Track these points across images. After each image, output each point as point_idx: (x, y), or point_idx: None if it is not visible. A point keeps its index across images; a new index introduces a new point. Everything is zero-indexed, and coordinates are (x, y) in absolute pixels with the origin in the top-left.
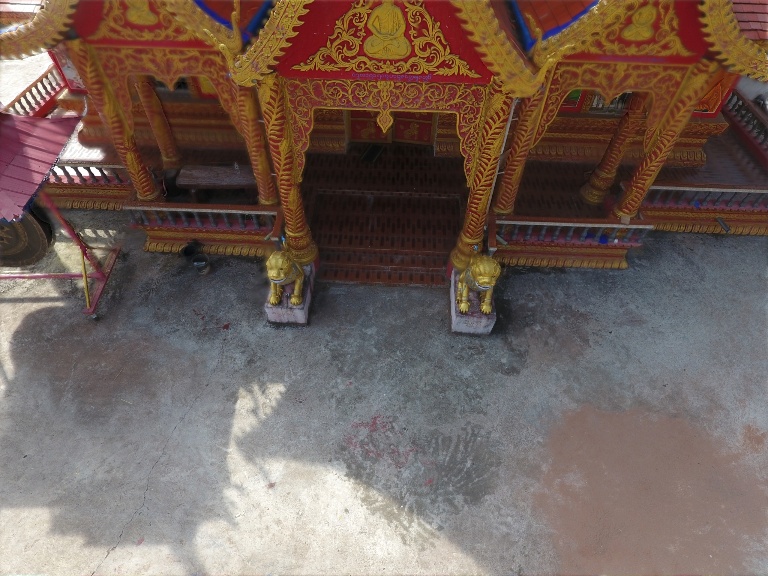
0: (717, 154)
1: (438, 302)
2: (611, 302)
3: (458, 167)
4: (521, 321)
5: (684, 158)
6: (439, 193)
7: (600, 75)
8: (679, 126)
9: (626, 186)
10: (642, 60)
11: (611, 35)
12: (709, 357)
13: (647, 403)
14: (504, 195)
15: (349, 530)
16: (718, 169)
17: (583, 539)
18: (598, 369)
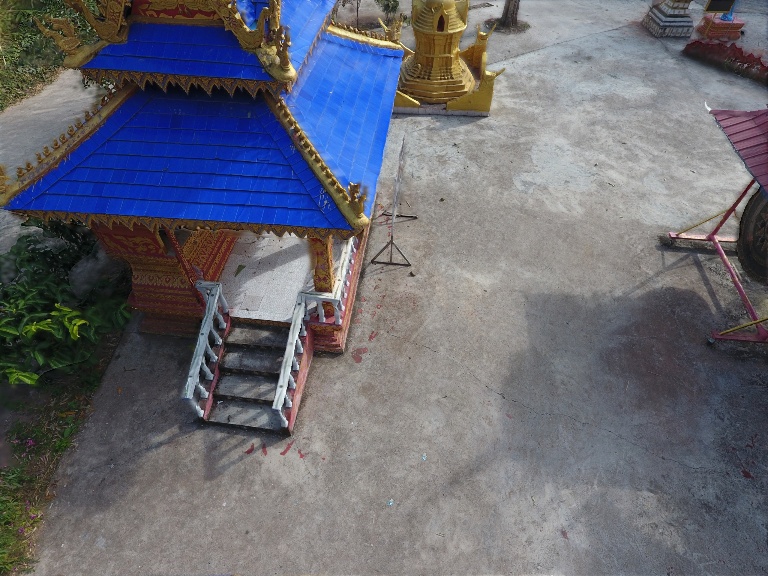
0: None
1: None
2: None
3: None
4: None
5: None
6: None
7: None
8: None
9: None
10: None
11: None
12: None
13: None
14: None
15: None
16: None
17: None
18: None
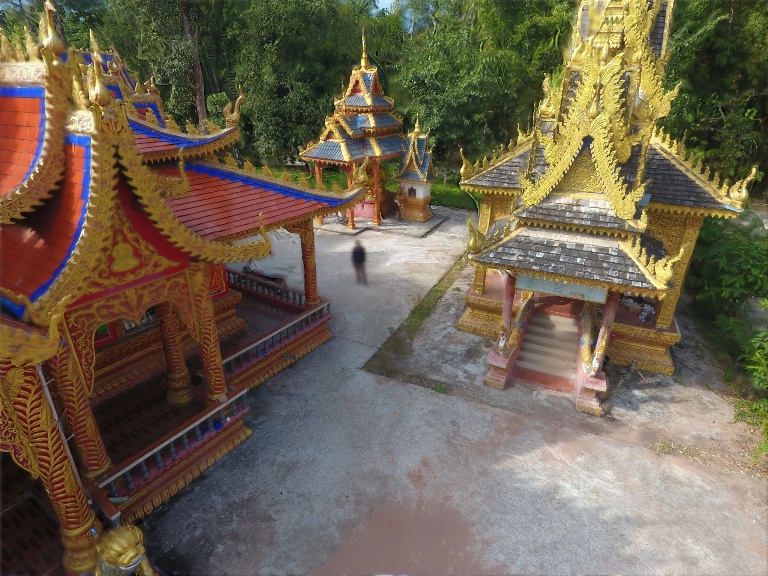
0: (248, 314)
1: None
2: (262, 469)
3: (6, 464)
4: (200, 558)
5: (229, 329)
6: None
7: (115, 306)
8: (209, 312)
9: (203, 373)
10: (144, 281)
11: (102, 274)
12: (353, 450)
13: (348, 522)
14: (90, 455)
15: None
16: (257, 323)
17: None
18: (296, 532)
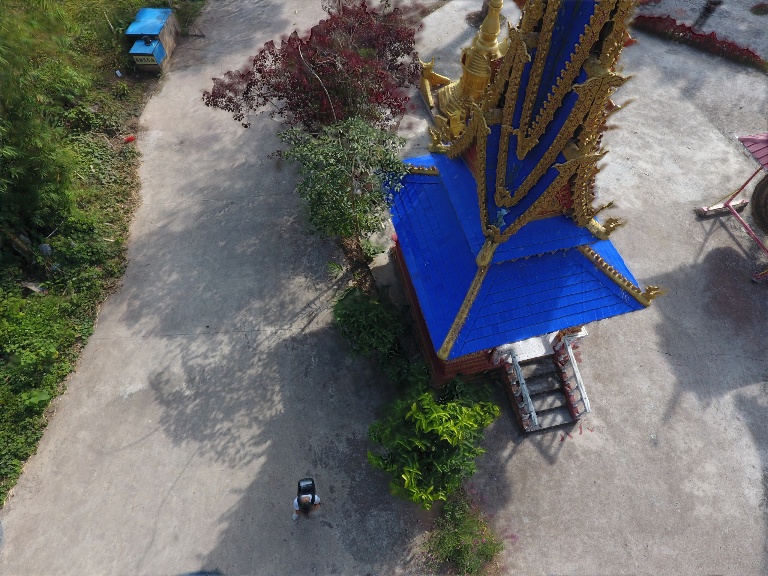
0: None
1: None
2: None
3: None
4: None
5: None
6: None
7: None
8: None
9: None
10: None
11: None
12: None
13: None
14: None
15: (746, 471)
16: None
17: None
18: None
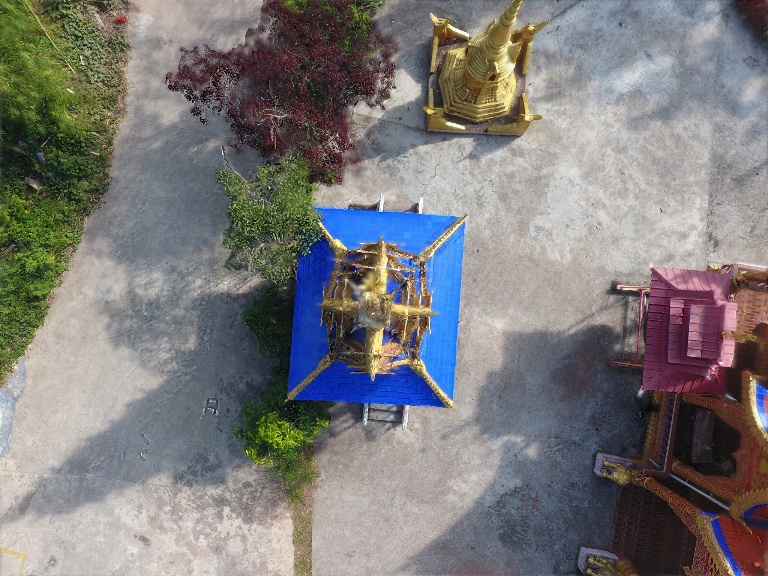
0: None
1: (601, 542)
2: None
3: None
4: None
5: None
6: (684, 564)
7: None
8: None
9: None
10: None
11: None
12: None
13: None
14: None
15: (496, 486)
16: None
17: (482, 575)
18: None
